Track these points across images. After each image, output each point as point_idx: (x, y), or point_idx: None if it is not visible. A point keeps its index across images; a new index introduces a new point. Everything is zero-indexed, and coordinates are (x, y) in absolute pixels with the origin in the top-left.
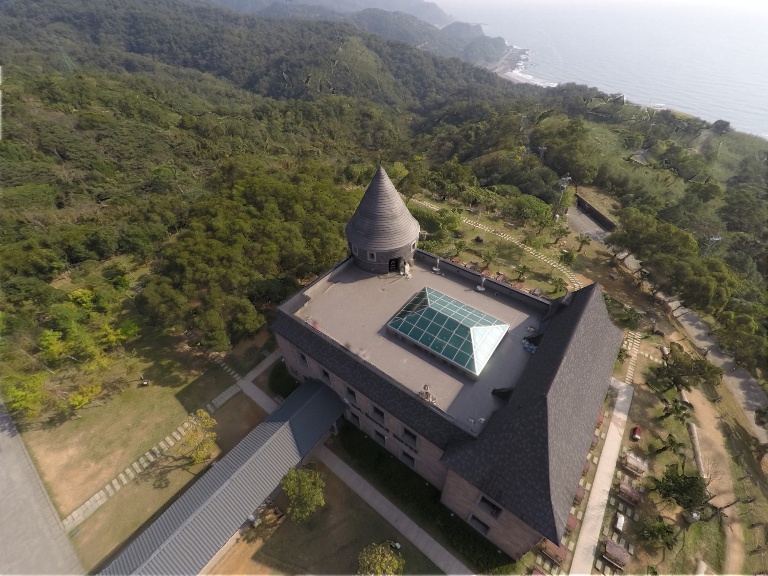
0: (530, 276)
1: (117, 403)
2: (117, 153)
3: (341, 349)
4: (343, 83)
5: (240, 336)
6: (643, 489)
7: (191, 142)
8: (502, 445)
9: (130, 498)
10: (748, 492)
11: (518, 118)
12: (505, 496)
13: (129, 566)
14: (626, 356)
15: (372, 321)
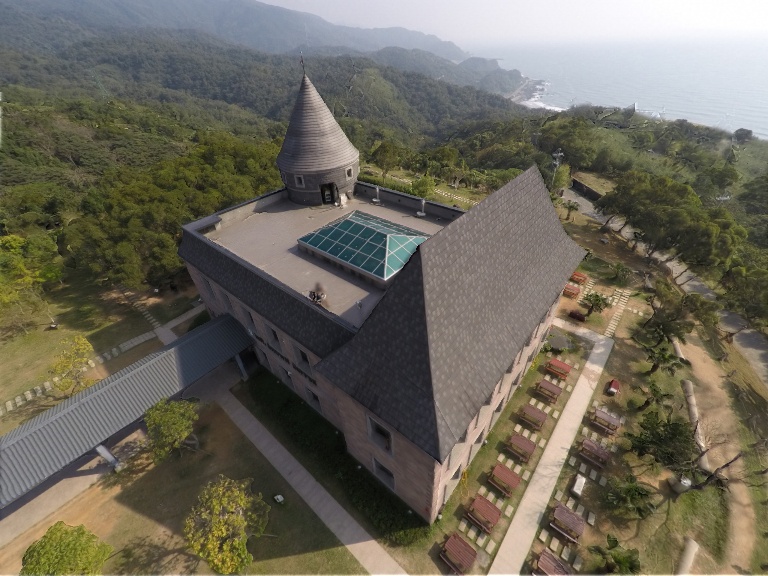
0: None
1: (17, 344)
2: (129, 161)
3: (231, 257)
4: (357, 107)
5: (160, 277)
6: (616, 449)
7: None
8: (378, 331)
9: None
10: (763, 461)
11: (521, 122)
12: (381, 402)
13: None
14: (605, 304)
15: (285, 241)
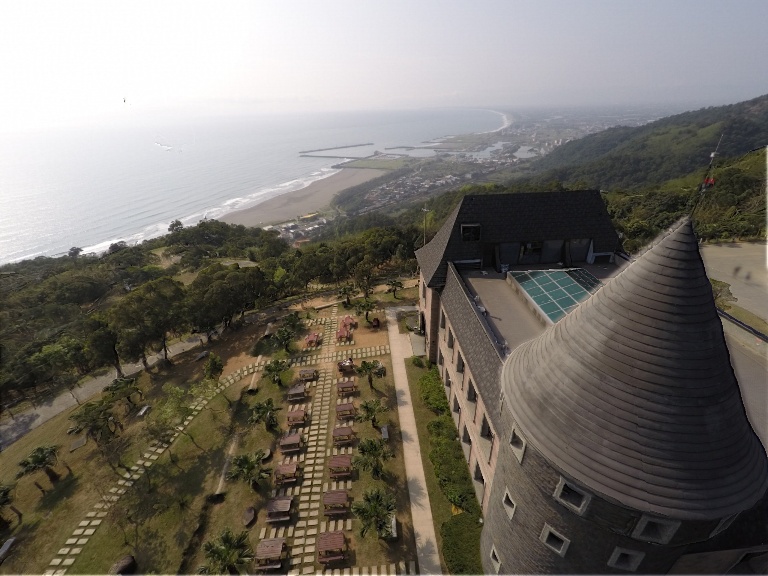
0: (242, 427)
1: None
2: None
3: None
4: None
5: None
6: None
7: None
8: None
9: None
10: None
11: None
12: None
13: None
14: None
15: None
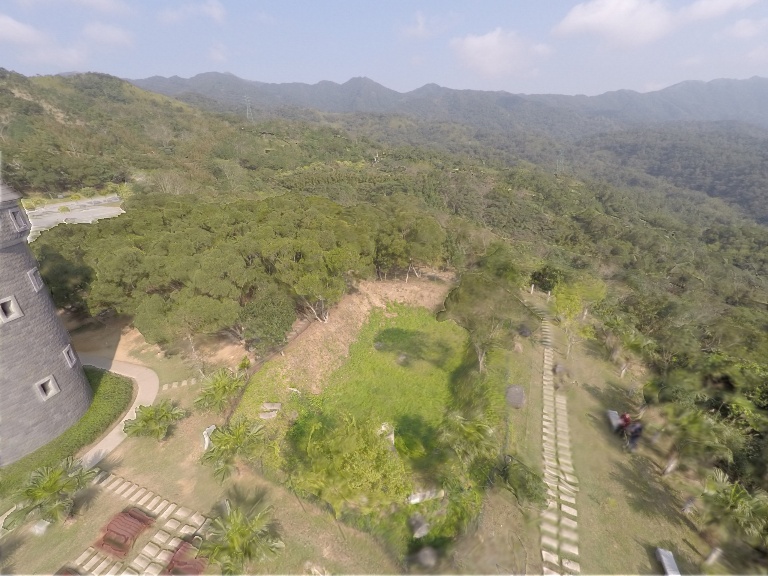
0: None
1: None
2: (491, 220)
3: None
4: None
5: None
6: None
7: (564, 231)
8: None
9: None
10: None
11: None
12: None
13: None
14: None
15: None
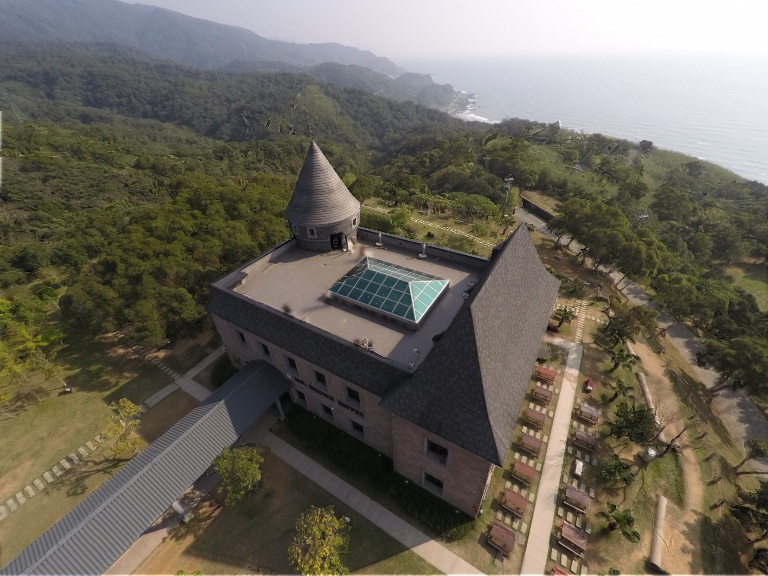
0: None
1: (32, 413)
2: (66, 193)
3: (276, 313)
4: (303, 125)
5: (177, 329)
6: (599, 435)
7: (147, 180)
8: (436, 372)
9: (36, 510)
10: (699, 429)
11: (466, 142)
12: (445, 426)
13: (17, 570)
14: (572, 317)
15: (312, 290)
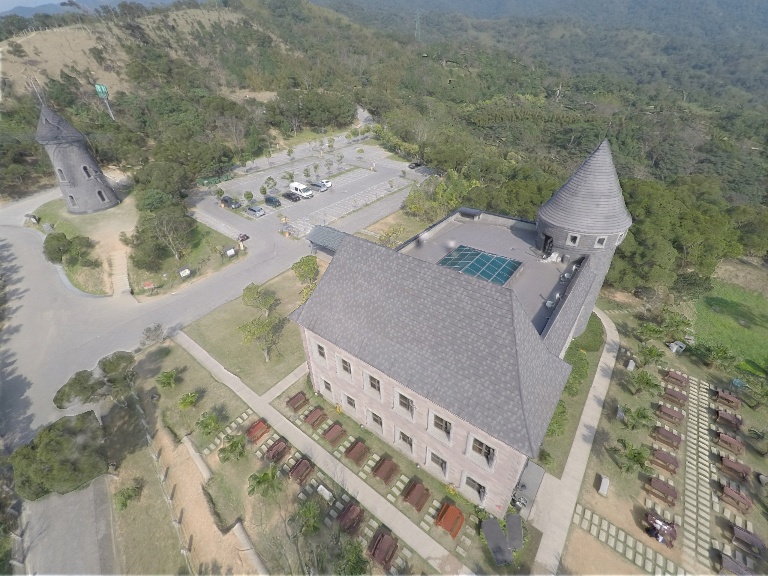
0: None
1: (419, 224)
2: None
3: None
4: None
5: None
6: None
7: None
8: None
9: (371, 240)
10: None
11: None
12: None
13: None
14: None
15: (468, 245)
